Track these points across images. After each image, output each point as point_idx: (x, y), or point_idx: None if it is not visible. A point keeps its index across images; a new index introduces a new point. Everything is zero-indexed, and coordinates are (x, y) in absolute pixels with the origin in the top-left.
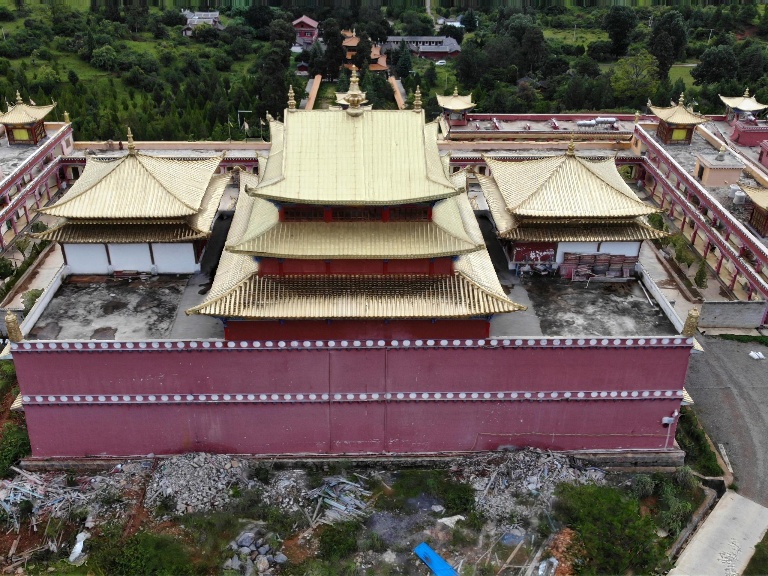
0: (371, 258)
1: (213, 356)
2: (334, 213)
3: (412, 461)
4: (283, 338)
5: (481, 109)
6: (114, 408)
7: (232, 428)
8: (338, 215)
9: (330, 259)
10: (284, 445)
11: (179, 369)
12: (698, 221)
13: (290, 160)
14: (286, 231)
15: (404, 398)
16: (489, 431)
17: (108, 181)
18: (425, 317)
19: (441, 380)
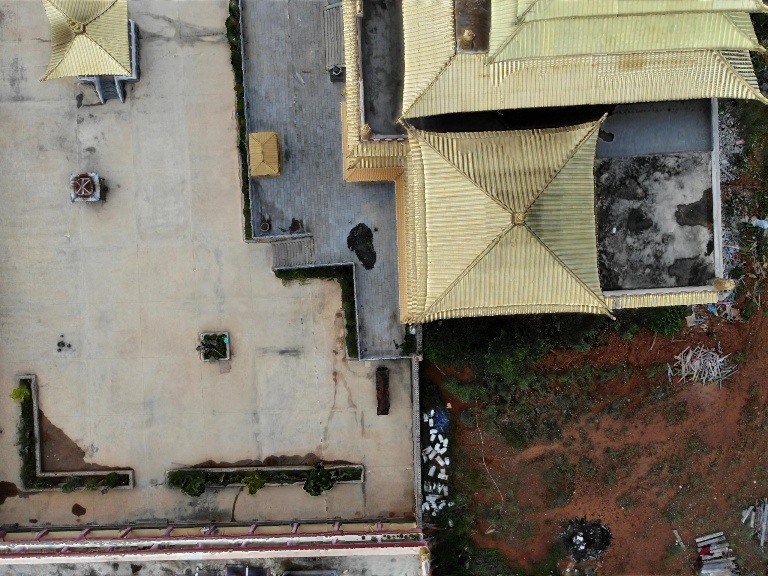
0: None
1: None
2: None
3: None
4: None
5: None
6: None
7: None
8: None
9: None
10: None
11: None
12: None
13: None
14: None
15: None
16: None
17: (552, 243)
18: None
19: None
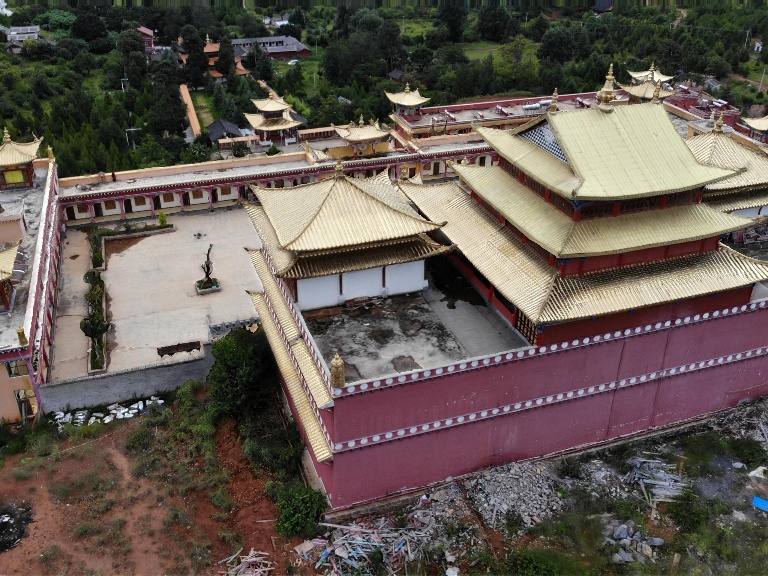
0: (669, 244)
1: (525, 364)
2: (621, 207)
3: (676, 430)
4: (589, 334)
5: (429, 103)
6: (423, 438)
7: (526, 434)
8: (624, 208)
9: (635, 251)
10: (569, 440)
11: (491, 384)
12: None
13: (577, 161)
14: (586, 230)
15: (675, 372)
16: (734, 389)
17: (328, 207)
18: (718, 291)
19: (707, 349)
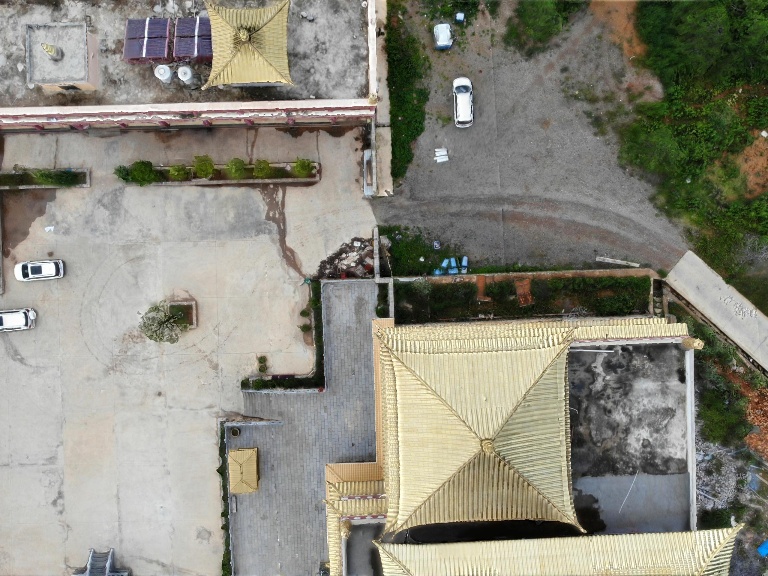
0: None
1: None
2: None
3: None
4: None
5: None
6: None
7: None
8: None
9: None
10: None
11: None
12: (160, 120)
13: None
14: None
15: None
16: None
17: None
18: None
19: None
